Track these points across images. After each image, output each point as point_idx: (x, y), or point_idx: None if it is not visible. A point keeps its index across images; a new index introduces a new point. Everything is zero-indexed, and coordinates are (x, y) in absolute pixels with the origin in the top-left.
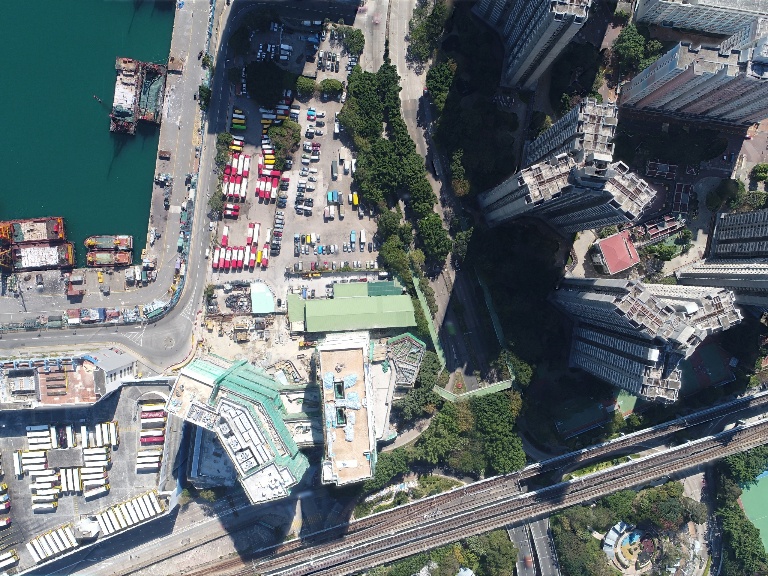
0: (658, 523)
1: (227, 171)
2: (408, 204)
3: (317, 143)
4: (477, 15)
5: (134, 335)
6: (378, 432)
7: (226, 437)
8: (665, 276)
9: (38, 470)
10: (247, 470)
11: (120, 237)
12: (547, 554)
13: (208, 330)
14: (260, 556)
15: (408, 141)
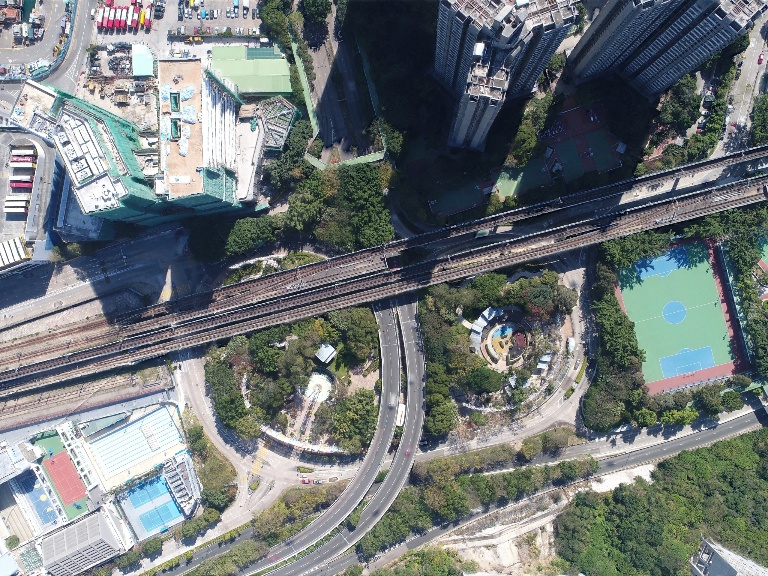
0: (525, 307)
1: None
2: None
3: None
4: None
5: None
6: (243, 193)
7: None
8: None
9: None
10: (81, 179)
11: None
12: (413, 339)
13: (90, 92)
14: None
15: None
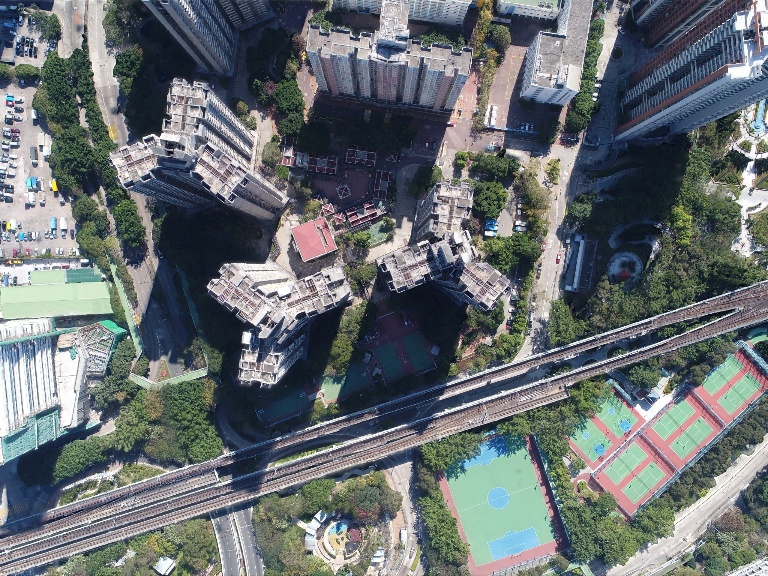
0: (352, 512)
1: None
2: None
3: (16, 129)
4: None
5: None
6: (67, 420)
7: None
8: (367, 264)
9: None
10: None
11: None
12: (251, 543)
13: None
14: None
15: (101, 127)
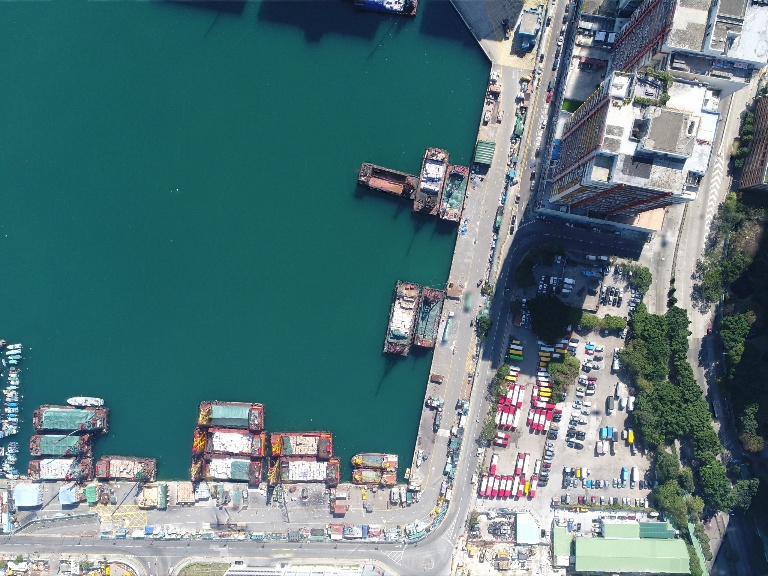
0: None
1: (501, 401)
2: (684, 444)
3: (594, 378)
4: None
5: (394, 554)
6: None
7: None
8: None
9: None
10: None
11: (390, 459)
12: None
13: (469, 555)
14: None
15: (694, 386)
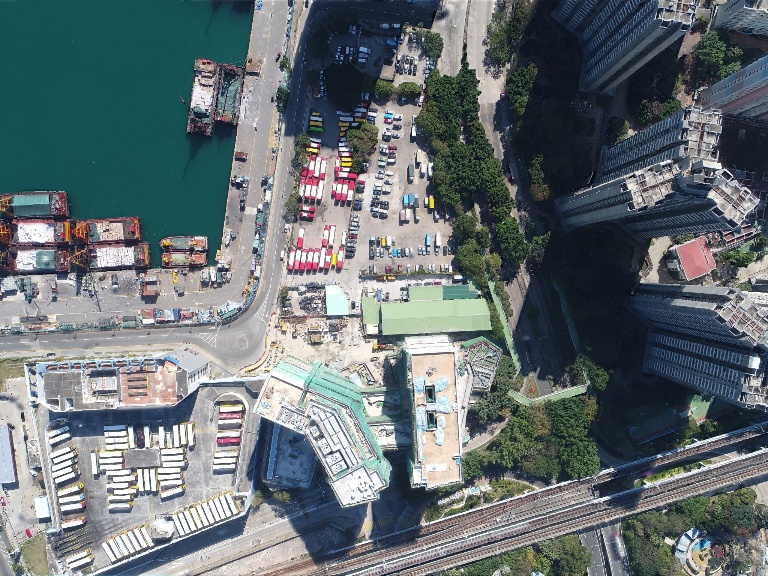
0: (732, 529)
1: (304, 173)
2: (483, 208)
3: (394, 146)
4: (556, 20)
5: (208, 336)
6: None
7: (315, 440)
8: (740, 282)
9: (115, 470)
10: (337, 473)
11: (196, 238)
12: (618, 559)
13: (282, 332)
14: (332, 558)
15: (486, 145)
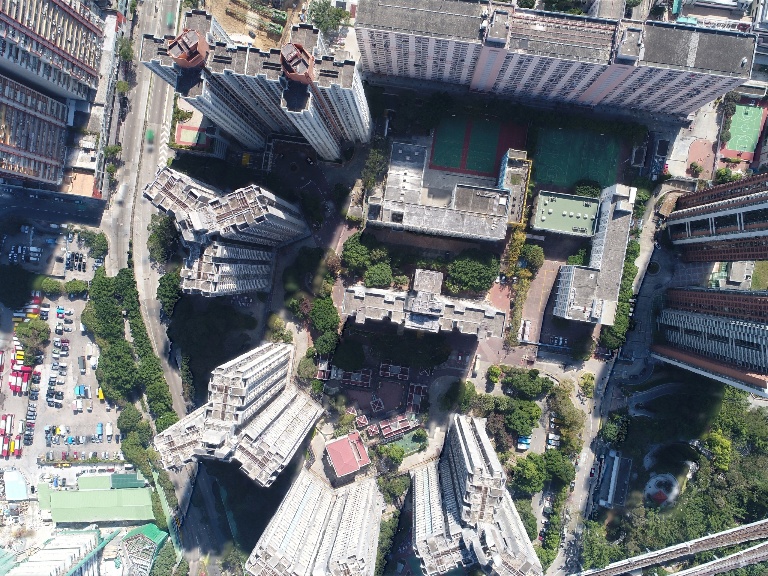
0: None
1: None
2: None
3: (65, 340)
4: None
5: None
6: None
7: None
8: (400, 474)
9: None
10: None
11: None
12: None
13: None
14: None
15: (145, 342)
